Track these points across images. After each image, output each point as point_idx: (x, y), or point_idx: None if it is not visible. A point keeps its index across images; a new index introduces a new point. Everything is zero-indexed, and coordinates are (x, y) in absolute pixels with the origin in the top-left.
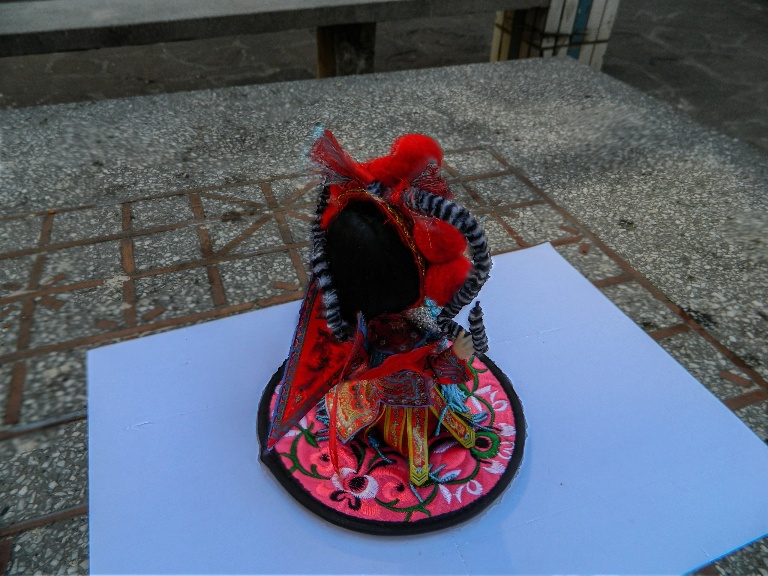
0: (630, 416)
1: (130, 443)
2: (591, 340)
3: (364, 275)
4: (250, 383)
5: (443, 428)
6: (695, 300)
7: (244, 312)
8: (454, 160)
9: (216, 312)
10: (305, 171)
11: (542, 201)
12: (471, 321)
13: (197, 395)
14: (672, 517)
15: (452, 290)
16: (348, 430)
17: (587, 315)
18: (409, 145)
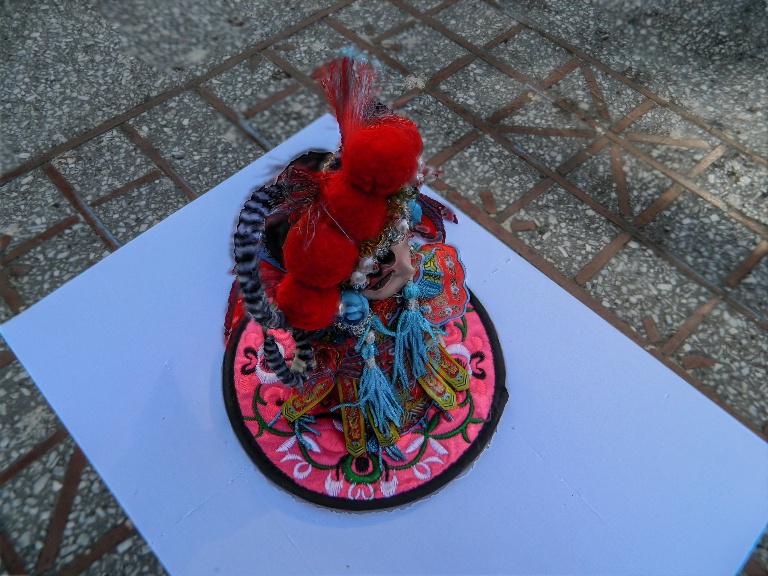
0: None
1: (254, 190)
2: (609, 573)
3: None
4: None
5: None
6: None
7: (431, 187)
8: None
9: None
10: (713, 124)
11: None
12: None
13: None
14: None
15: None
16: None
17: (662, 559)
18: (358, 137)
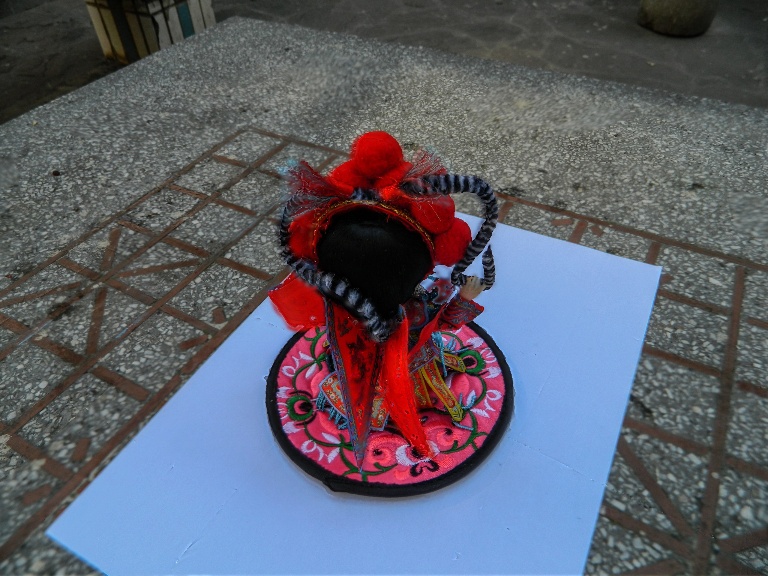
0: (532, 283)
1: (194, 572)
2: None
3: (397, 272)
4: (252, 443)
5: (445, 368)
6: (499, 181)
7: (178, 389)
8: (229, 152)
9: (149, 406)
10: (92, 227)
11: (335, 156)
12: (487, 264)
13: (214, 487)
14: (605, 331)
15: (464, 247)
16: (379, 418)
17: None
18: (378, 145)
